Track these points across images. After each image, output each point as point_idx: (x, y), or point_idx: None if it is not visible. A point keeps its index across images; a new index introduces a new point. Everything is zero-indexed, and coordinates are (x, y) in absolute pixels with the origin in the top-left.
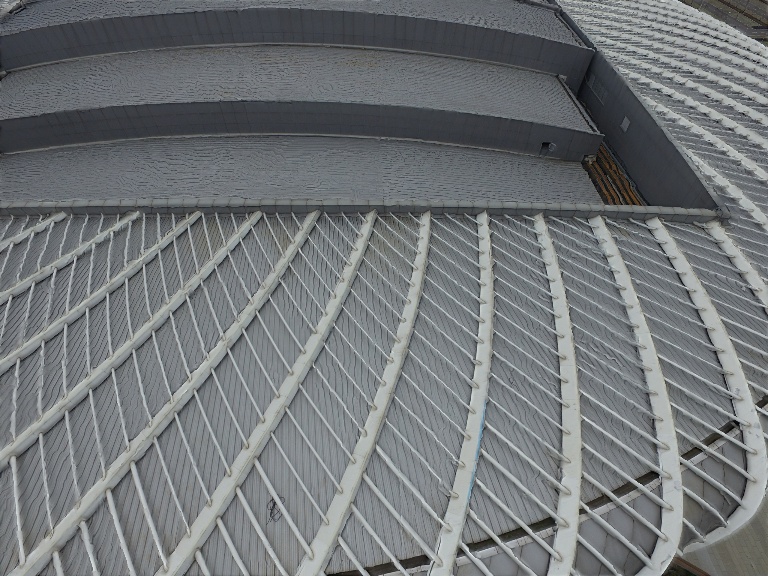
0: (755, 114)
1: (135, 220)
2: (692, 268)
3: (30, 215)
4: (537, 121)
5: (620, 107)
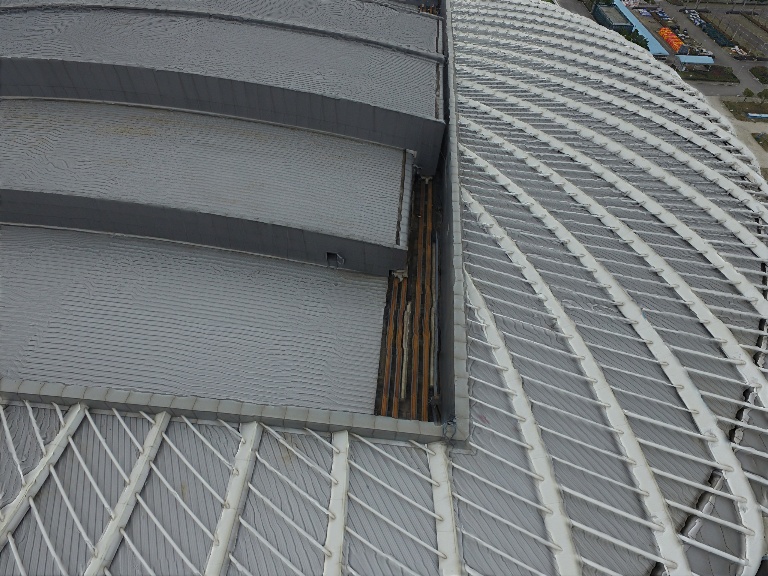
0: (626, 233)
1: None
2: (343, 547)
3: None
4: (312, 226)
5: (447, 207)
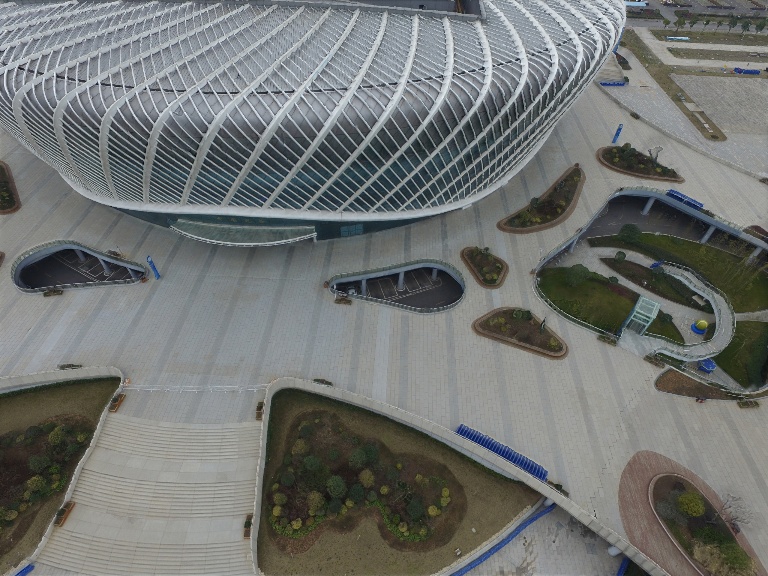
0: None
1: (190, 5)
2: (451, 31)
3: (142, 2)
4: None
5: None
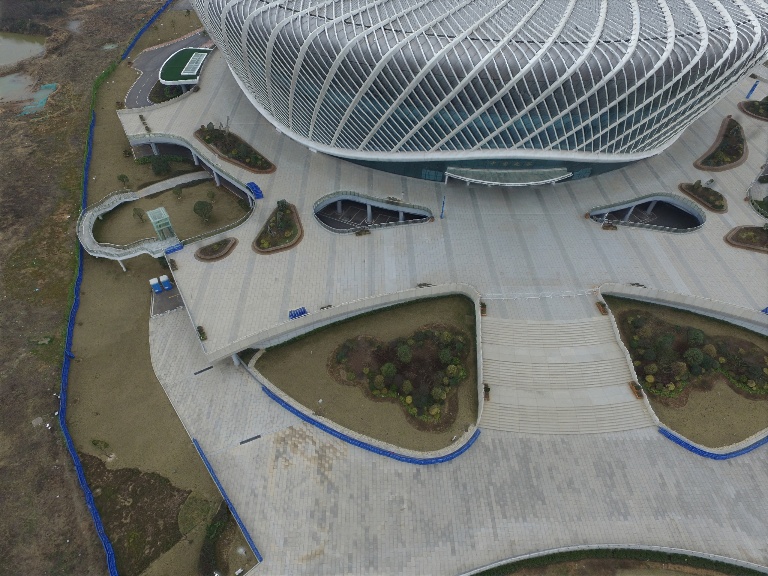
0: None
1: None
2: None
3: None
4: None
5: None
